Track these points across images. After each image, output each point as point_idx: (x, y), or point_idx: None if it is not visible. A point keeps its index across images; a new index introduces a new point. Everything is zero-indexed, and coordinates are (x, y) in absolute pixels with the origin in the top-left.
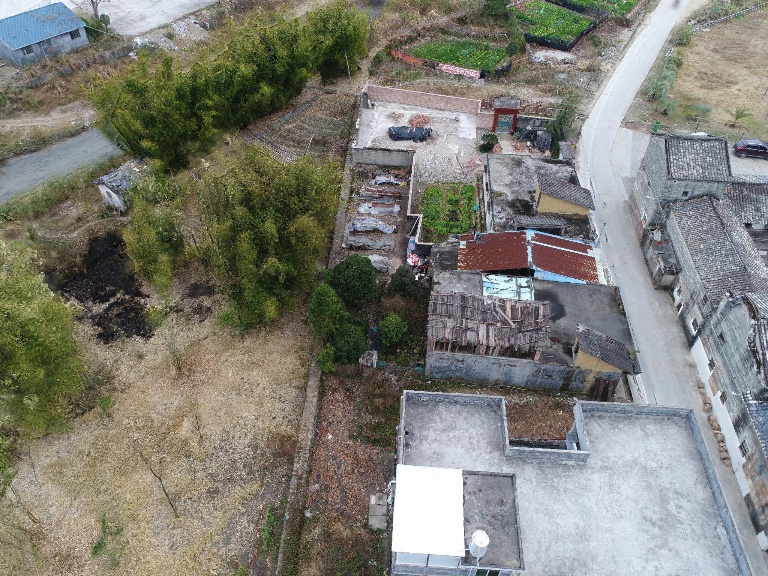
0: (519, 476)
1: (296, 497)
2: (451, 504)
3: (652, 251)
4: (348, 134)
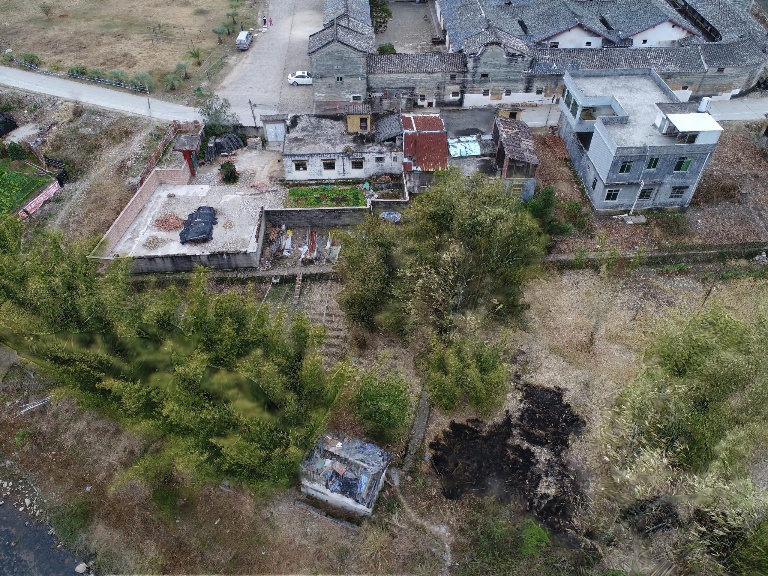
0: (635, 120)
1: (653, 251)
2: (687, 116)
3: (388, 101)
4: (181, 285)
